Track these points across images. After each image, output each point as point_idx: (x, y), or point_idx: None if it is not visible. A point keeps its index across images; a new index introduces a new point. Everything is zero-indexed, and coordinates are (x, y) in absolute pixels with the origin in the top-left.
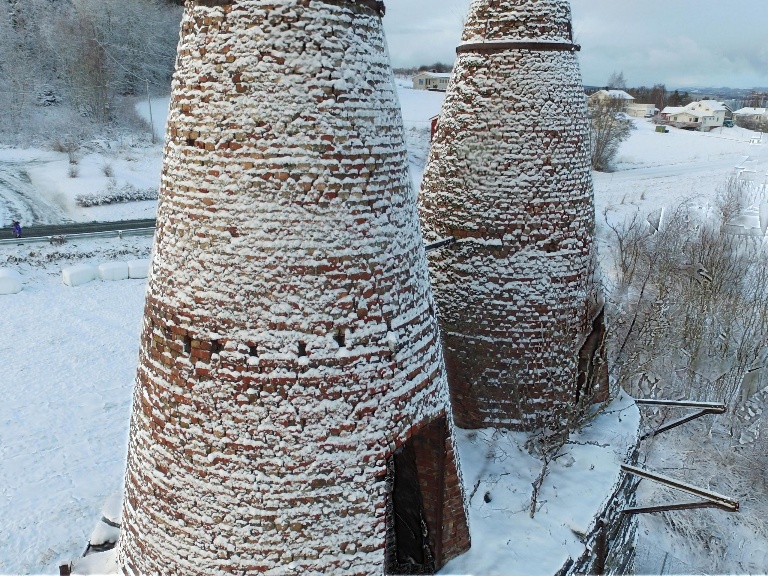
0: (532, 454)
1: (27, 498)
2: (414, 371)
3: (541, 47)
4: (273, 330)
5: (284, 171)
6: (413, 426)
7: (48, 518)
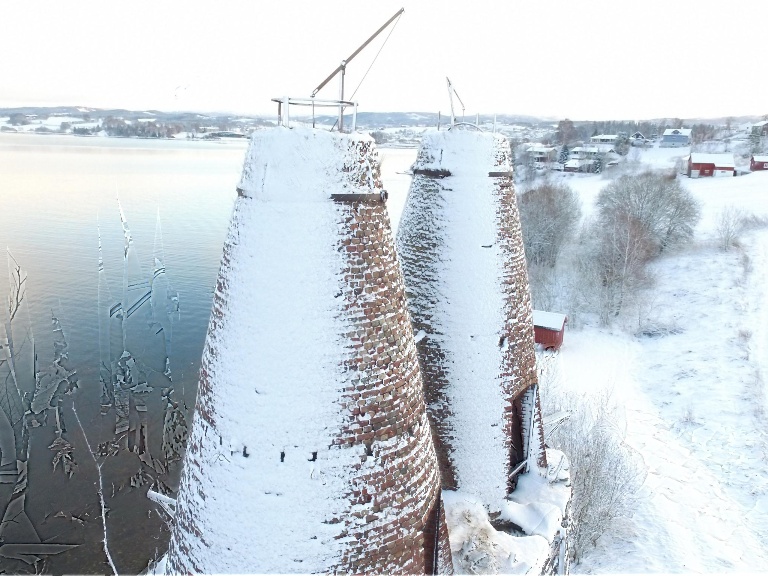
0: None
1: None
2: None
3: None
4: None
5: None
6: None
7: None
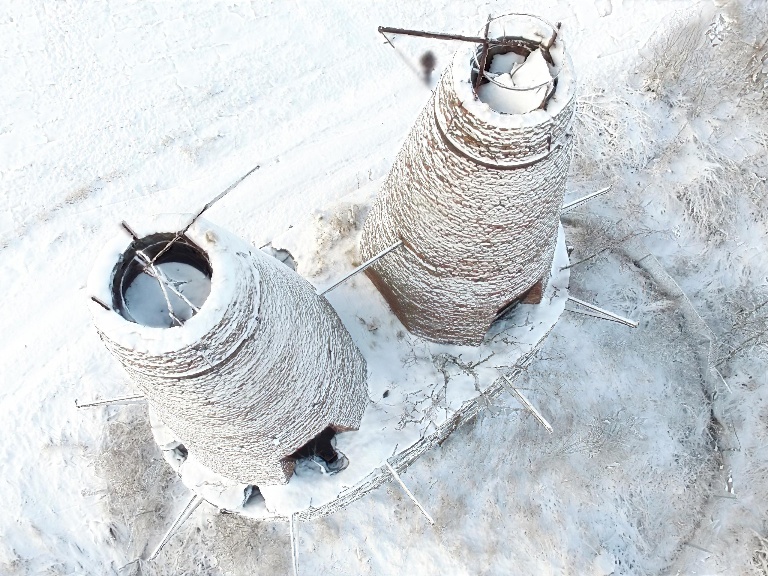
0: (435, 363)
1: (142, 79)
2: None
3: (501, 167)
4: None
5: None
6: None
7: (161, 103)
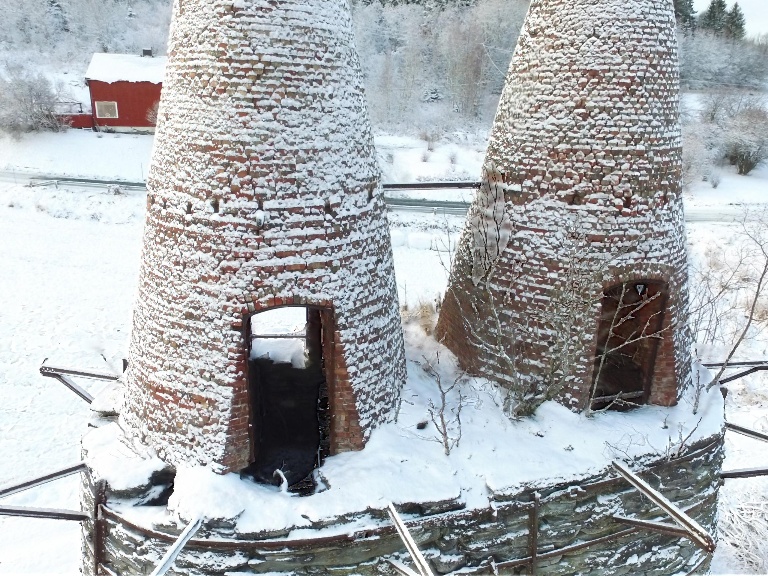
0: (506, 412)
1: None
2: (286, 252)
3: None
4: (176, 191)
5: (194, 71)
6: (277, 298)
7: None
